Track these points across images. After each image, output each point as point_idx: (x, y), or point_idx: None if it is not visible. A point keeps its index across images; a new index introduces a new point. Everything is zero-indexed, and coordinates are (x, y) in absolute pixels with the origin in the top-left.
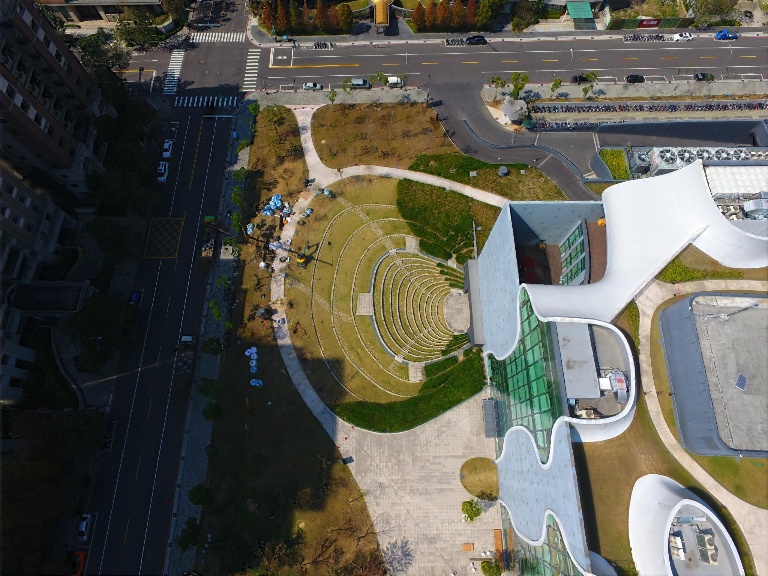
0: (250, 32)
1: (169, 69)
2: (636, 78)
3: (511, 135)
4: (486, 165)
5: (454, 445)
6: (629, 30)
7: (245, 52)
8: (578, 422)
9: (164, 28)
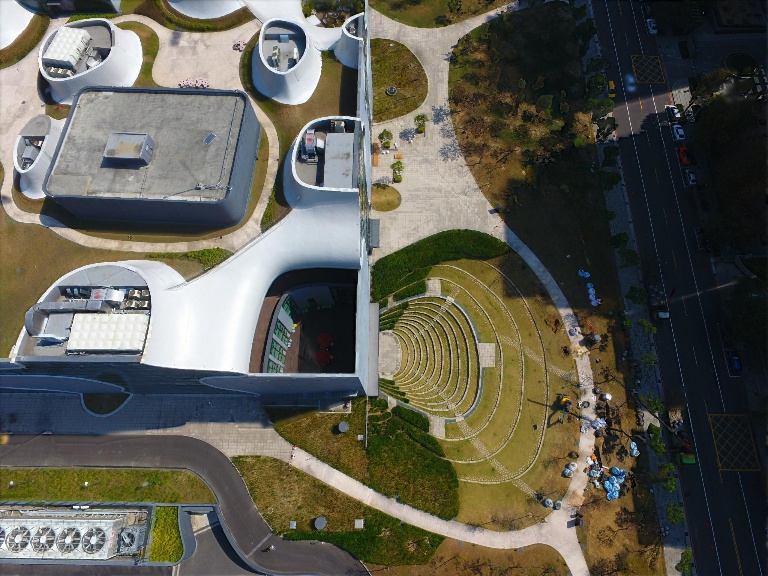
0: None
1: None
2: None
3: None
4: (340, 539)
5: (405, 220)
6: None
7: None
8: (349, 117)
9: None
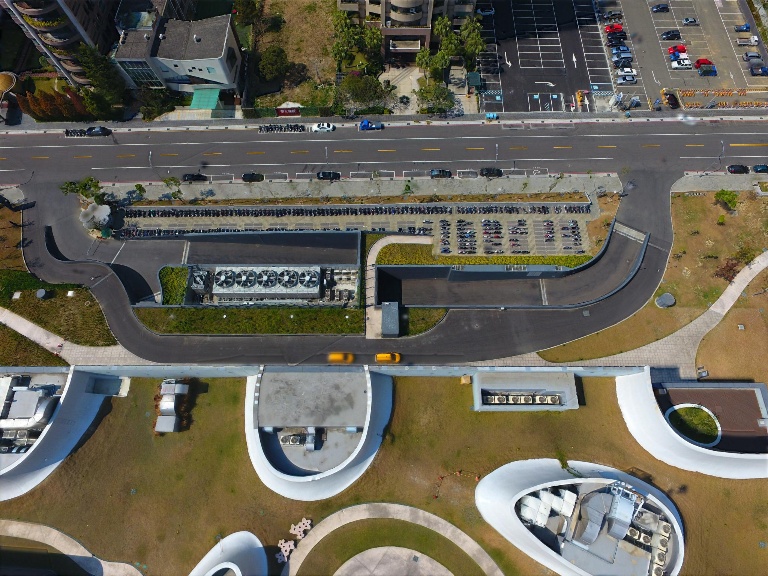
0: None
1: None
2: (250, 177)
3: None
4: (35, 285)
5: None
6: (269, 119)
7: None
8: None
9: None
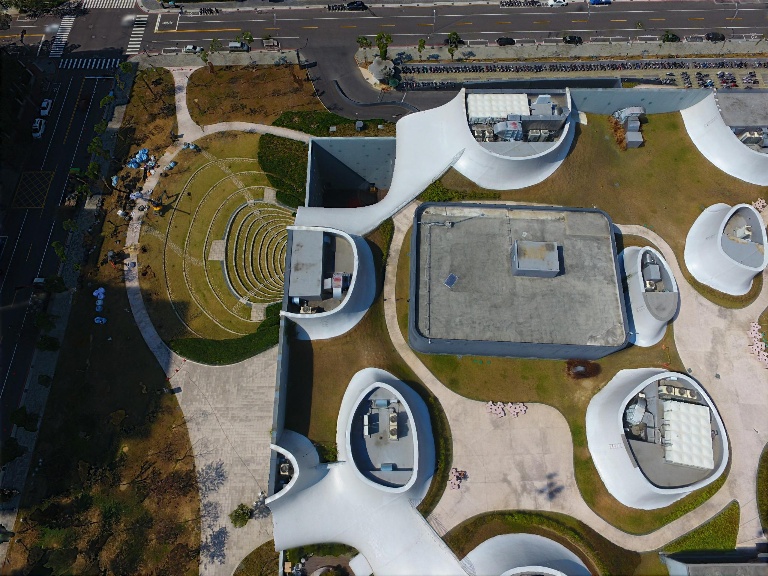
0: None
1: (58, 34)
2: (505, 40)
3: (379, 94)
4: (346, 120)
5: None
6: None
7: None
8: (293, 316)
9: None
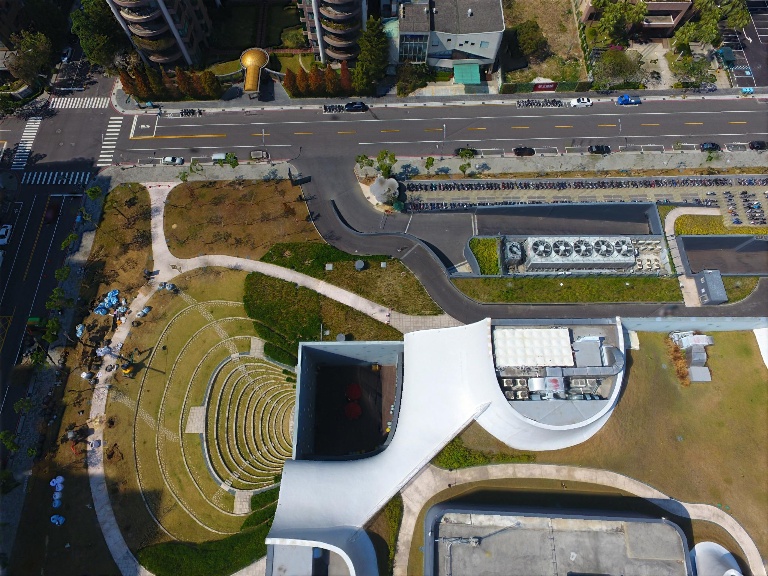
0: (115, 97)
1: (21, 140)
2: (524, 151)
3: (381, 217)
4: (344, 256)
5: None
6: (524, 94)
7: (106, 120)
8: None
9: (20, 94)
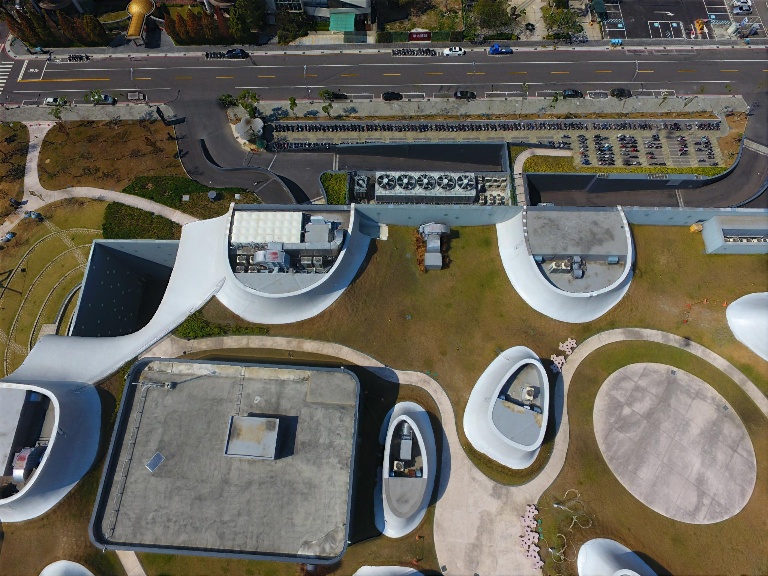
0: (9, 43)
1: None
2: (391, 95)
3: None
4: (201, 189)
5: None
6: (400, 43)
7: None
8: None
9: None
